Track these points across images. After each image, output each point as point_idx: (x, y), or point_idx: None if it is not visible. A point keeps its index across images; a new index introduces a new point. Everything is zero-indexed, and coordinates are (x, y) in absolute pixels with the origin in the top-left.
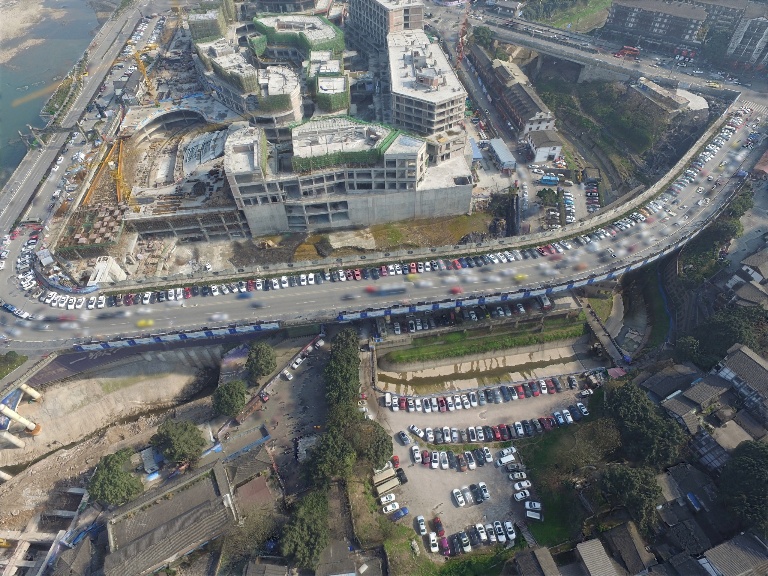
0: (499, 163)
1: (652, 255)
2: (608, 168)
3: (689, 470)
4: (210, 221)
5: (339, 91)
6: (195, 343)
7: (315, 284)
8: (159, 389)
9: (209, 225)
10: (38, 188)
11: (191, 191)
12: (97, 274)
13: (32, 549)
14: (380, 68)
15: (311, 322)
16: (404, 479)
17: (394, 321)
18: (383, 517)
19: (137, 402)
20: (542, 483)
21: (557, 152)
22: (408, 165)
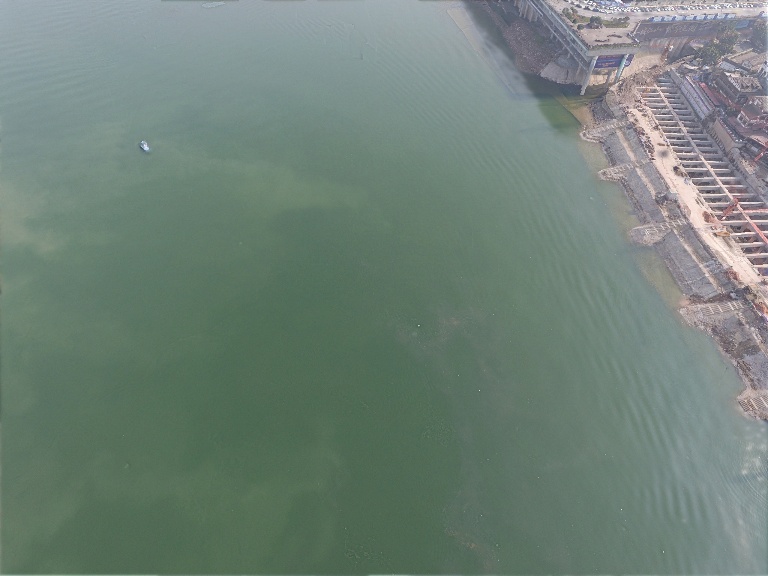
0: None
1: None
2: None
3: None
4: None
5: None
6: (678, 34)
7: (733, 8)
8: (656, 60)
9: None
10: None
11: None
12: None
13: None
14: None
15: (746, 17)
16: None
17: None
18: None
19: None
20: None
21: None
22: None
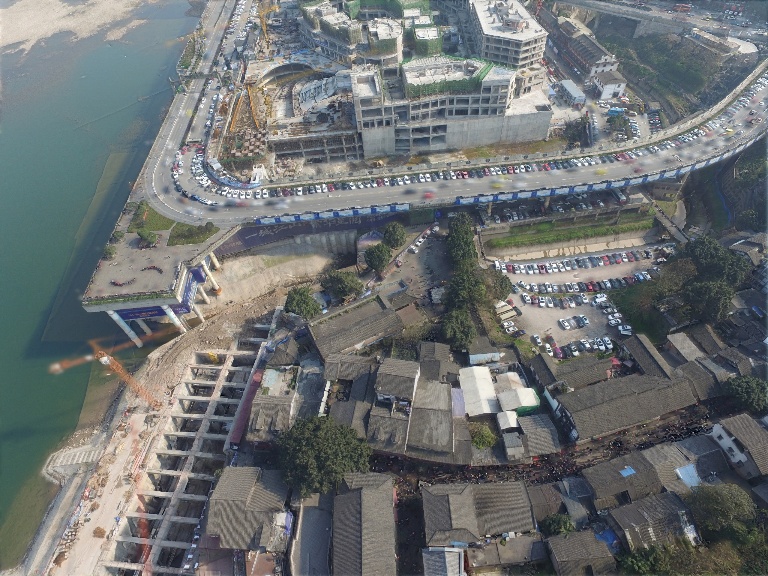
0: (570, 99)
1: (714, 157)
2: (665, 107)
3: (753, 291)
4: (333, 143)
5: (435, 38)
6: (337, 228)
7: (431, 181)
8: (306, 266)
9: (332, 147)
10: (192, 119)
11: (316, 120)
12: (255, 177)
13: (234, 364)
14: (462, 23)
15: (434, 206)
16: (520, 312)
17: (494, 214)
18: (506, 336)
19: (290, 276)
20: (631, 313)
21: (621, 89)
22: (501, 91)
